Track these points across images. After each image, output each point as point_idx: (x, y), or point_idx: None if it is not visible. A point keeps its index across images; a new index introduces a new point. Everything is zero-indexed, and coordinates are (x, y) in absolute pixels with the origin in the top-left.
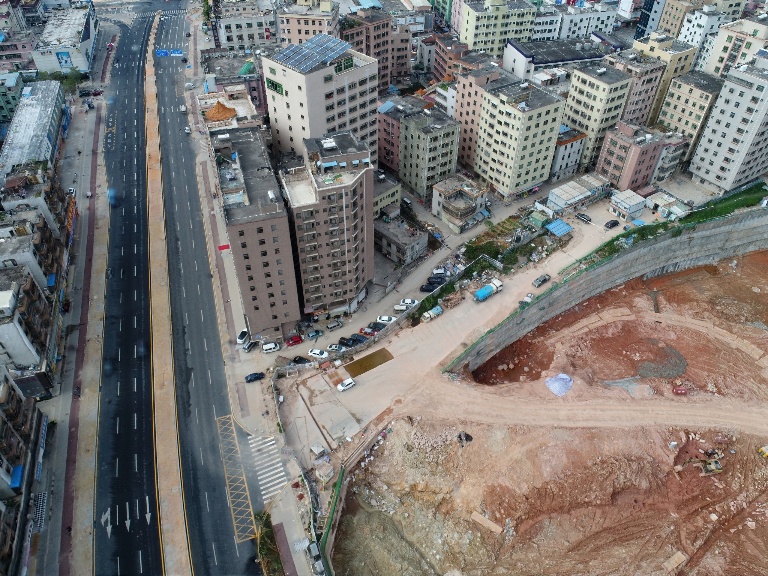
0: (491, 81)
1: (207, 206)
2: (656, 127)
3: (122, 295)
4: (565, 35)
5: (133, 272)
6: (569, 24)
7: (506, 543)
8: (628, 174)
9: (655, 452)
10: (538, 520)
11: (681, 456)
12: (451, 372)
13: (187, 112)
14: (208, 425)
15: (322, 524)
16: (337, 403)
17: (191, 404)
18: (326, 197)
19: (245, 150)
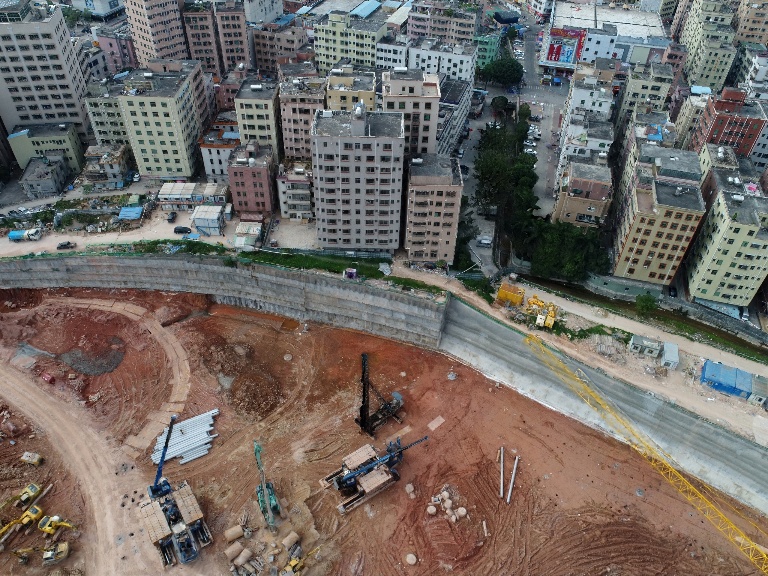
0: (171, 71)
1: None
2: (309, 162)
3: None
4: None
5: None
6: (416, 58)
7: None
8: None
9: None
10: None
11: None
12: None
13: None
14: None
15: None
16: None
17: None
18: None
19: None
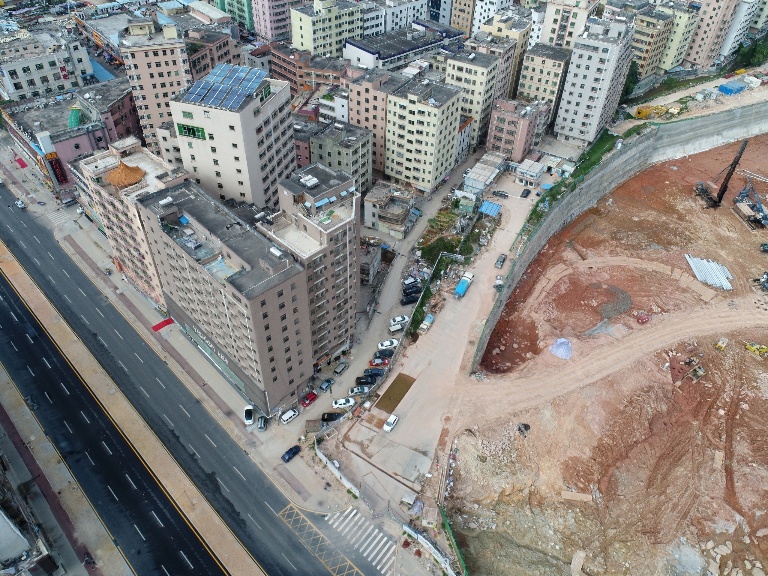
0: (383, 83)
1: (106, 286)
2: (520, 99)
3: (67, 423)
4: (390, 28)
5: (63, 391)
6: (392, 17)
7: (600, 507)
8: (520, 146)
9: (656, 378)
10: (610, 474)
11: (672, 373)
12: (474, 373)
13: (4, 183)
14: (274, 526)
15: (457, 569)
16: (393, 445)
17: (239, 512)
18: (333, 238)
19: (194, 210)
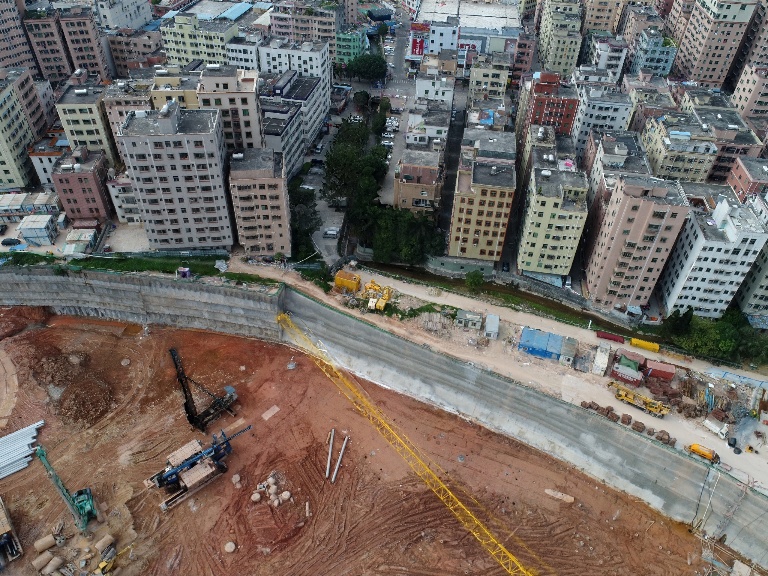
0: None
1: None
2: None
3: None
4: (266, 68)
5: None
6: (266, 57)
7: None
8: None
9: None
10: None
11: None
12: None
13: None
14: None
15: None
16: None
17: None
18: None
19: None
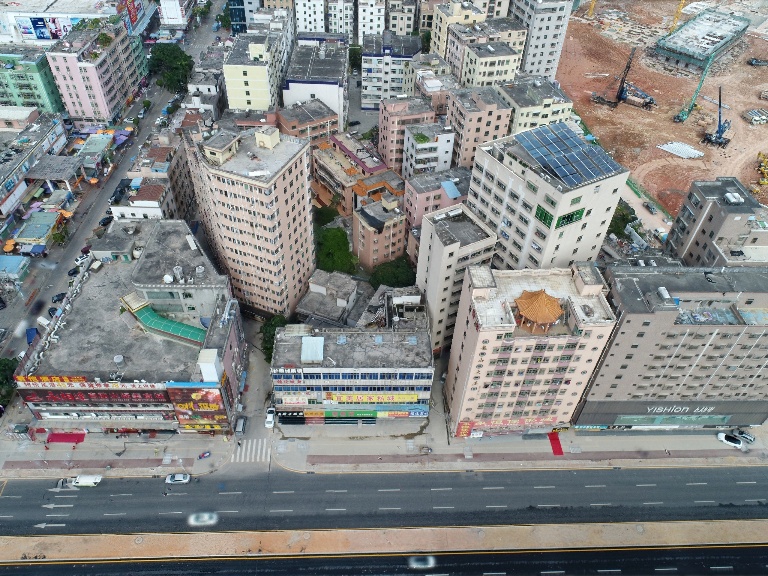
0: None
1: (450, 463)
2: None
3: None
4: (286, 52)
5: (613, 574)
6: (286, 40)
7: None
8: None
9: None
10: None
11: None
12: None
13: None
14: None
15: None
16: None
17: None
18: None
19: None
